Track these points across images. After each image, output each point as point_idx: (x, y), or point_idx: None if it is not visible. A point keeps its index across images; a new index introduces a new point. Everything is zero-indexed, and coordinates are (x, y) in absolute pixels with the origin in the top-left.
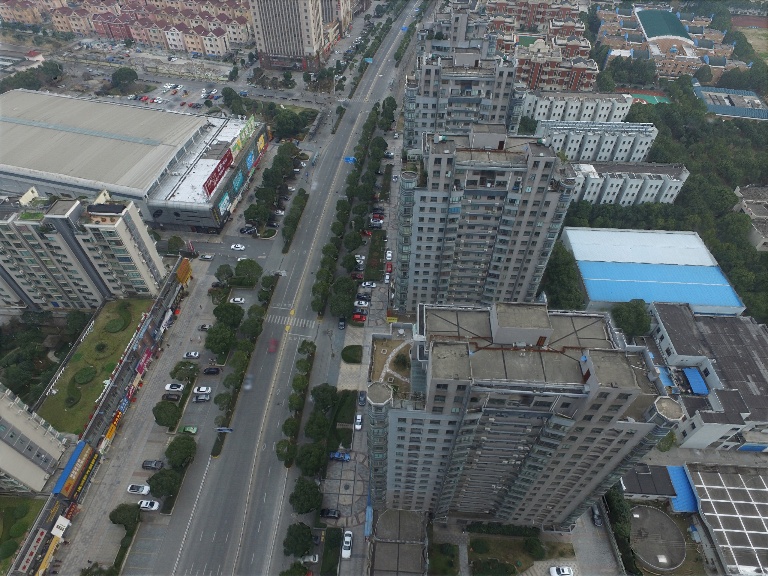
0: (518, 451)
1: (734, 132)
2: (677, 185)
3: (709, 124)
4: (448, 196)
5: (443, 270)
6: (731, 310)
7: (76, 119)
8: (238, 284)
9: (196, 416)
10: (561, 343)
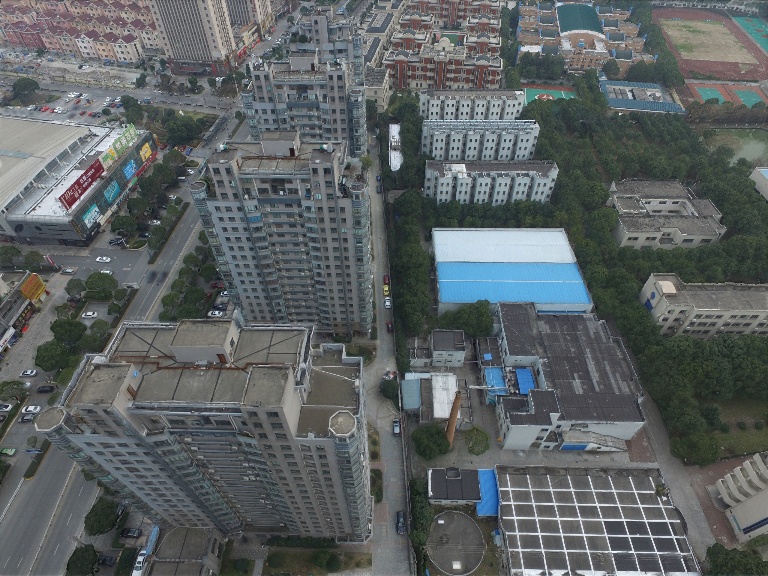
0: (249, 468)
1: (628, 126)
2: (545, 182)
3: (605, 118)
4: (240, 205)
5: (268, 279)
6: (580, 307)
7: None
8: (94, 298)
9: (19, 437)
10: (248, 359)
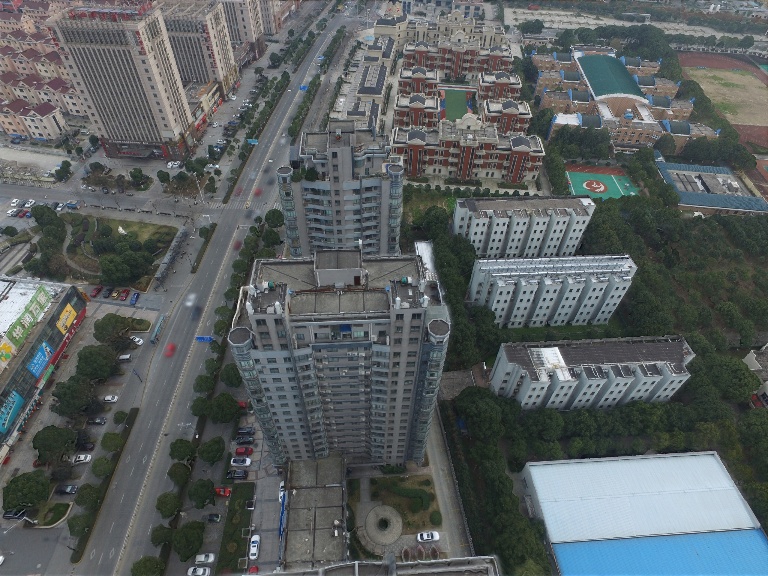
0: None
1: (719, 237)
2: (681, 379)
3: (687, 225)
4: None
5: None
6: None
7: None
8: None
9: None
10: None
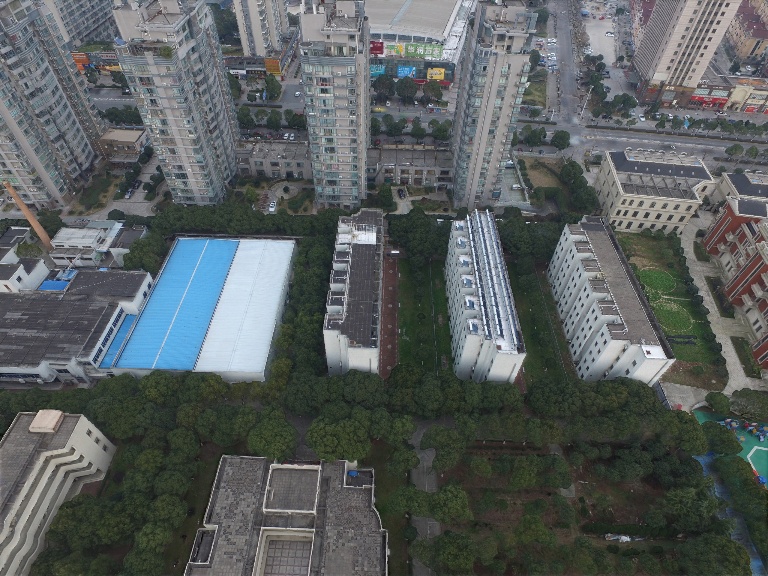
0: None
1: None
2: None
3: None
4: None
5: None
6: None
7: (425, 0)
8: None
9: None
10: None
